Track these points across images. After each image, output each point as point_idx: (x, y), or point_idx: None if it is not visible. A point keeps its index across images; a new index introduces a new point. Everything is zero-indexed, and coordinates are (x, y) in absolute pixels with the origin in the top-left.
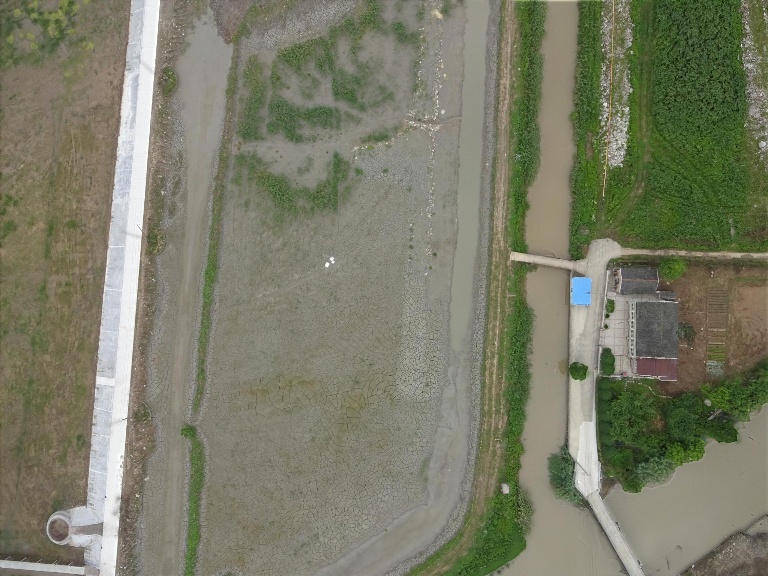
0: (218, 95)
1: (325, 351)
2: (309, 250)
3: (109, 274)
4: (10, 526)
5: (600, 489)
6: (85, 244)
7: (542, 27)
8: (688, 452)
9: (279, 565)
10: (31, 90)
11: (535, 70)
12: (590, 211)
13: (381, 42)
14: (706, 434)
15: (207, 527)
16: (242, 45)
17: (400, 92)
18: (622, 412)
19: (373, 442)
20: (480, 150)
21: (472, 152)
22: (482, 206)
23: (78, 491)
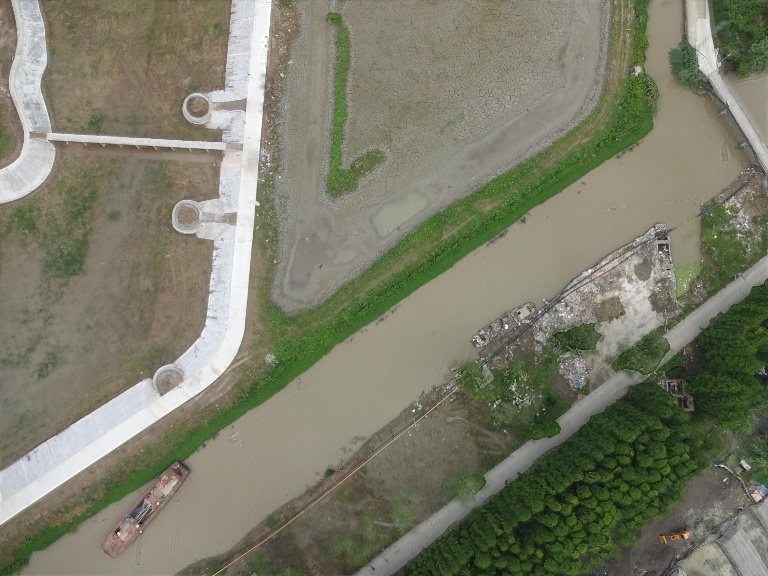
0: None
1: None
2: None
3: None
4: (138, 112)
5: None
6: None
7: None
8: None
9: (426, 141)
10: None
11: None
12: None
13: None
14: None
15: (353, 108)
16: None
17: None
18: (735, 1)
19: (514, 31)
20: None
21: None
22: None
23: (215, 77)
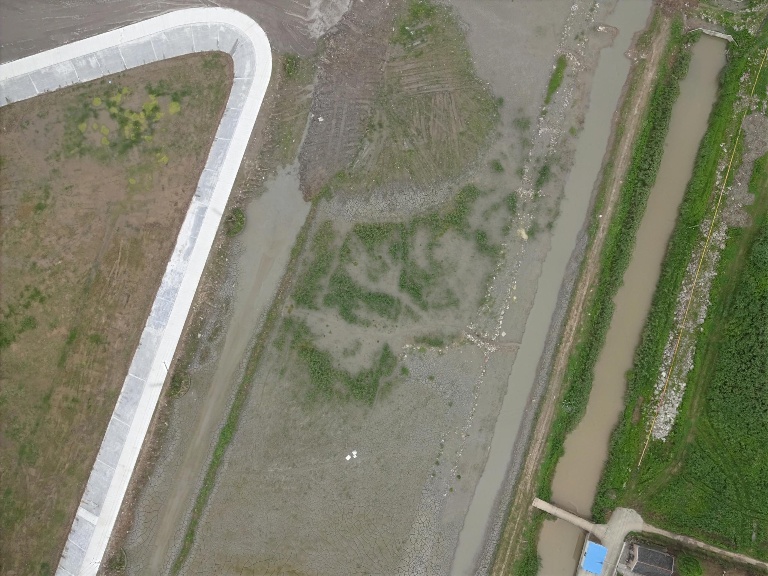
0: (283, 251)
1: (323, 546)
2: (334, 437)
3: (121, 403)
4: None
5: None
6: (104, 363)
7: (622, 278)
8: None
9: None
10: (90, 186)
11: (604, 320)
12: (622, 477)
13: (460, 245)
14: None
15: None
16: (320, 207)
17: (466, 301)
18: None
19: None
20: (530, 383)
21: (522, 383)
22: (518, 441)
23: None
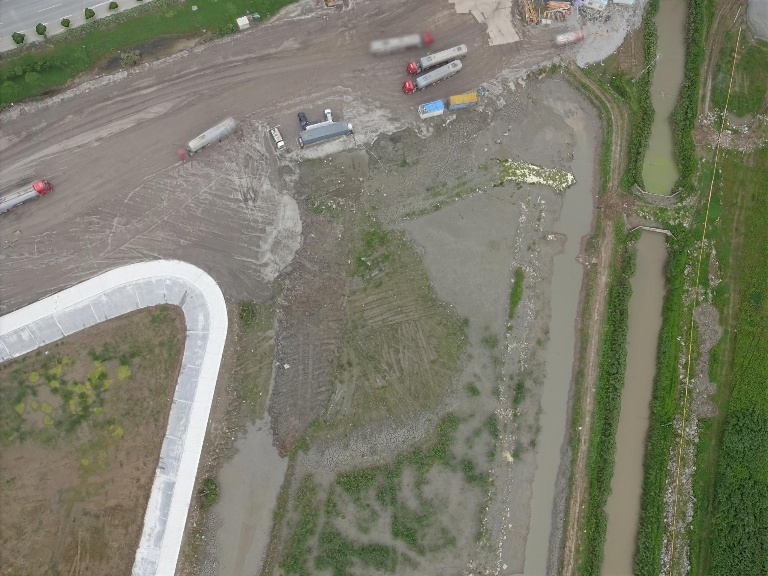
0: (264, 516)
1: None
2: None
3: None
4: None
5: None
6: None
7: (609, 487)
8: None
9: None
10: (36, 474)
11: (600, 534)
12: None
13: (448, 479)
14: None
15: None
16: (298, 460)
17: (463, 538)
18: None
19: None
20: None
21: None
22: None
23: None
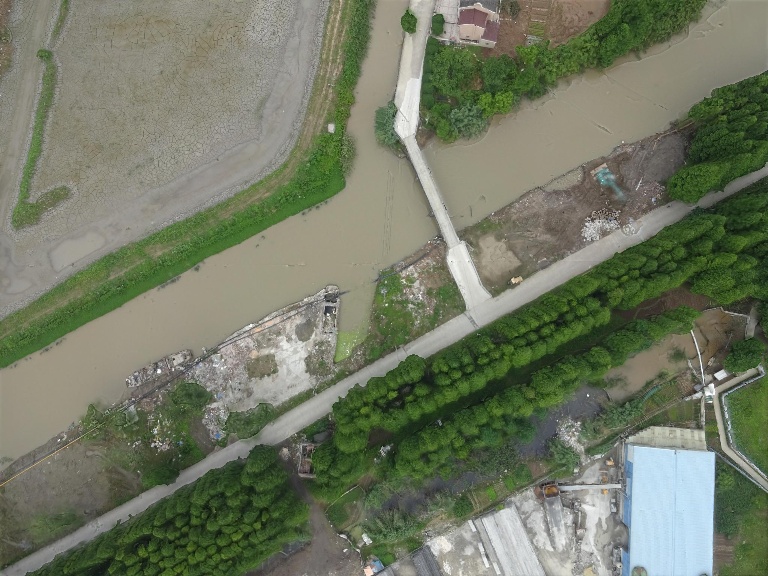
0: None
1: None
2: None
3: None
4: None
5: (418, 138)
6: None
7: None
8: (495, 96)
9: (113, 183)
10: None
11: None
12: None
13: None
14: (518, 96)
15: (49, 144)
16: None
17: None
18: (443, 64)
19: (217, 79)
20: None
21: None
22: None
23: None
